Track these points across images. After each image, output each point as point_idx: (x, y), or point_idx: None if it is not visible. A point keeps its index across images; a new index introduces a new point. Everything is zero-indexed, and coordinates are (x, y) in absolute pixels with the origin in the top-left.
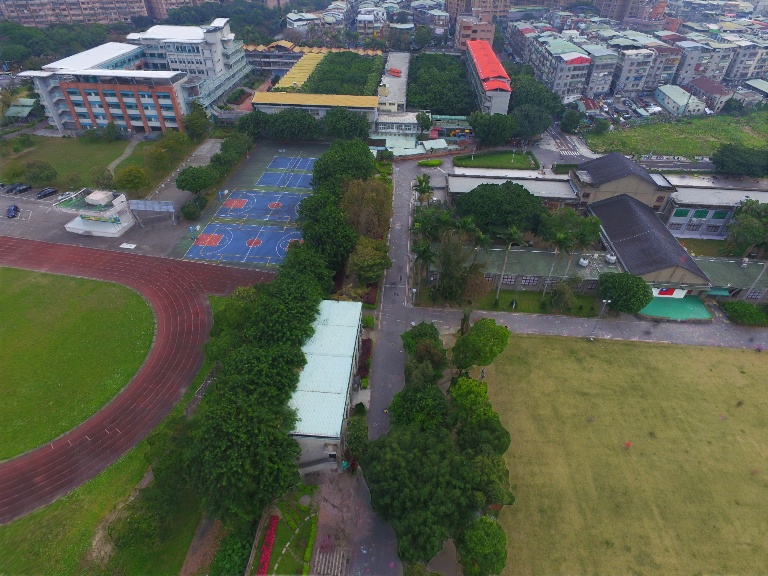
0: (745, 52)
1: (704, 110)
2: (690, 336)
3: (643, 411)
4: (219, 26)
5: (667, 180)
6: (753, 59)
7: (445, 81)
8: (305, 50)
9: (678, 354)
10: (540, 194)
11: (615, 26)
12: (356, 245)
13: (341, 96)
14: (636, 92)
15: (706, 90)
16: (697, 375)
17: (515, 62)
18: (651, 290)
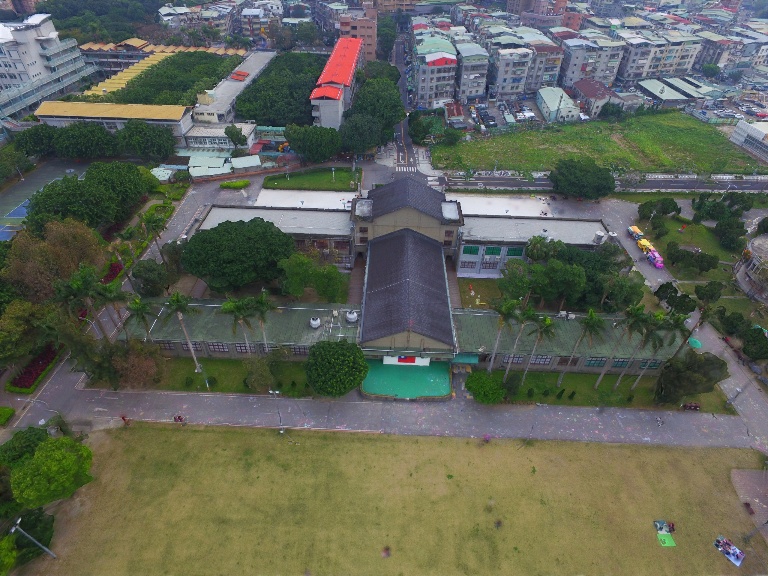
0: (636, 50)
1: (579, 116)
2: (412, 421)
3: (285, 547)
4: (33, 23)
5: (458, 211)
6: (646, 58)
7: (283, 86)
8: (157, 49)
9: (382, 450)
10: (308, 230)
11: (517, 21)
12: (4, 313)
13: (142, 106)
14: (517, 95)
15: (585, 93)
16: (388, 484)
17: (406, 61)
18: (362, 366)
